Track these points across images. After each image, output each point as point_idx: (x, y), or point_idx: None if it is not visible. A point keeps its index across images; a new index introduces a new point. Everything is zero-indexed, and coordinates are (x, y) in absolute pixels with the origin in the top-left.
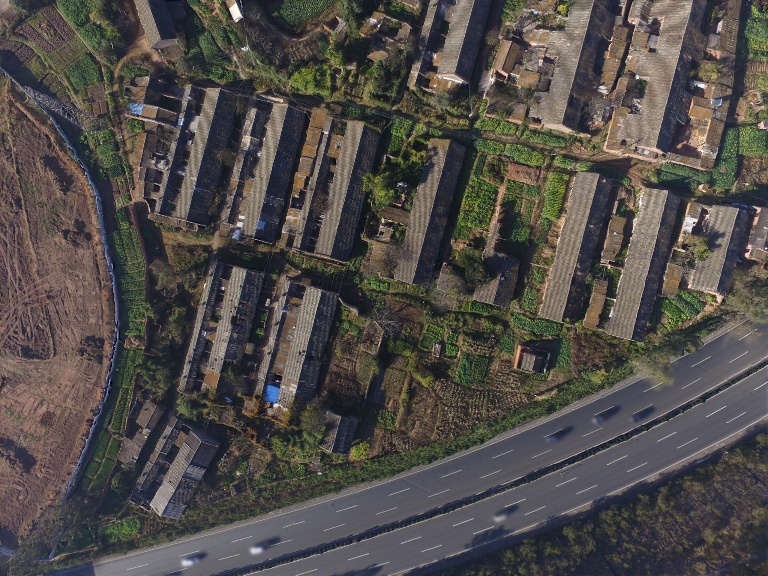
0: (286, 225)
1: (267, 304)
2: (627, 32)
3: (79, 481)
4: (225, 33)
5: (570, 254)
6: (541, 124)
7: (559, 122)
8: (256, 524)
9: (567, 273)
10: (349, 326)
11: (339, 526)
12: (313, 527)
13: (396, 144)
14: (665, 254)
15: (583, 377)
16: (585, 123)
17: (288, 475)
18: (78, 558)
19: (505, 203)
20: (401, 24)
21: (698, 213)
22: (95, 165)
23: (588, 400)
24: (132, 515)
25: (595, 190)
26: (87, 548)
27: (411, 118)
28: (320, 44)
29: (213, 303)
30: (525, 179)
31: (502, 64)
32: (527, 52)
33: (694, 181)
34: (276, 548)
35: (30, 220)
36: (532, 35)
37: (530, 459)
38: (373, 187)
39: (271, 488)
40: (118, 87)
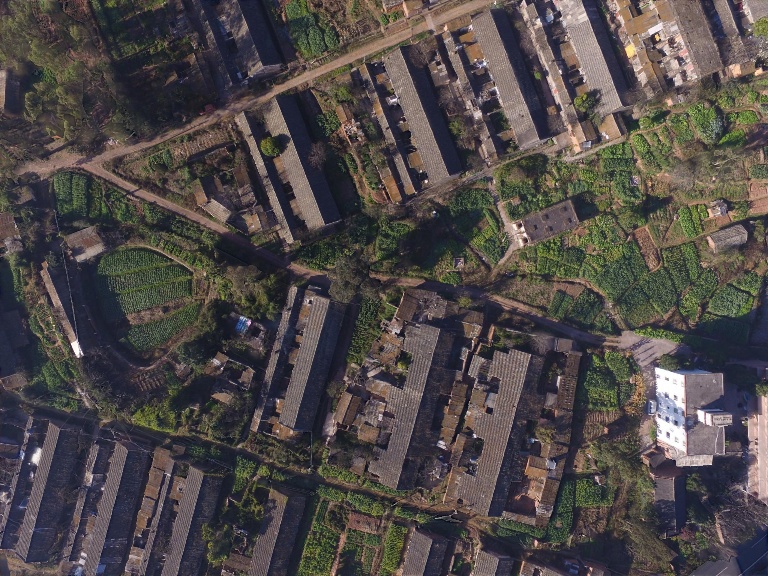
0: (129, 564)
1: None
2: (469, 383)
3: None
4: (67, 368)
5: None
6: None
7: (394, 487)
8: None
9: None
10: None
11: None
12: None
13: (240, 484)
14: None
15: None
16: None
17: None
18: None
19: (345, 552)
20: (245, 366)
21: (531, 573)
22: None
23: None
24: None
25: (428, 556)
26: None
27: (256, 457)
28: (167, 374)
29: None
30: (365, 529)
31: (342, 417)
32: (368, 404)
33: (529, 537)
34: None
35: None
36: (374, 385)
37: None
38: None
39: None
40: None
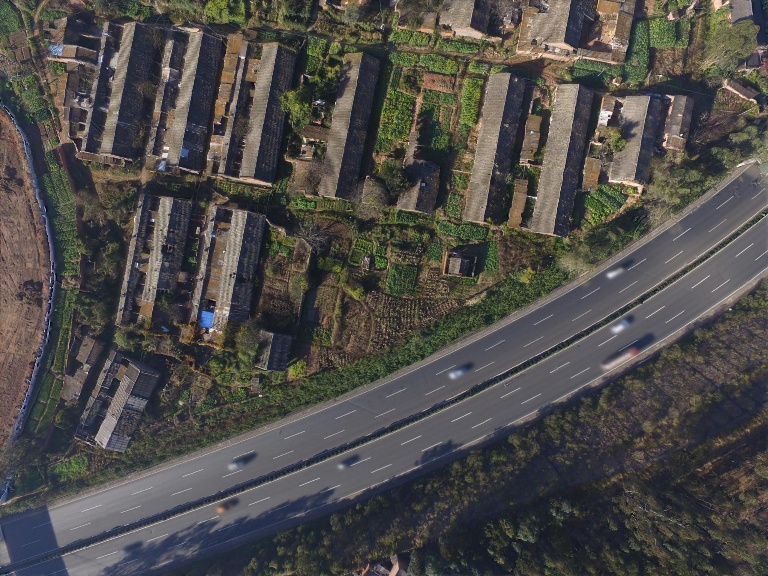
0: (210, 152)
1: (197, 232)
2: None
3: (25, 423)
4: None
5: (488, 155)
6: (452, 31)
7: (467, 25)
8: (206, 457)
9: (486, 174)
10: (279, 247)
11: (288, 453)
12: (262, 456)
13: (313, 64)
14: (582, 148)
15: (511, 278)
16: (497, 28)
17: (229, 400)
18: (29, 499)
19: (423, 112)
20: None
21: (612, 106)
22: (21, 111)
23: (527, 310)
24: (79, 453)
25: (507, 89)
26: (38, 490)
27: (326, 38)
28: None
29: (144, 235)
30: (441, 87)
31: None
32: None
33: (607, 75)
34: (227, 479)
35: None
36: None
37: (473, 373)
38: None
39: (214, 415)
40: (39, 32)
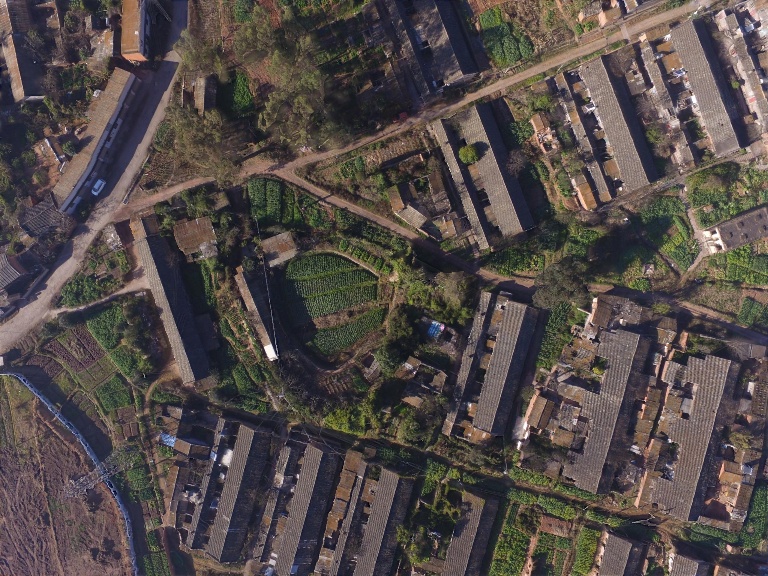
0: (319, 565)
1: None
2: (660, 388)
3: None
4: (259, 371)
5: None
6: (574, 482)
7: (593, 491)
8: None
9: None
10: None
11: None
12: None
13: (429, 486)
14: None
15: None
16: None
17: None
18: None
19: (537, 555)
20: (437, 370)
21: None
22: (125, 487)
23: None
24: None
25: (627, 560)
26: None
27: (445, 460)
28: (354, 378)
29: None
30: (557, 532)
31: (537, 422)
32: (562, 409)
33: (722, 542)
34: None
35: (58, 538)
36: (567, 390)
37: None
38: (407, 541)
39: None
40: (149, 411)
